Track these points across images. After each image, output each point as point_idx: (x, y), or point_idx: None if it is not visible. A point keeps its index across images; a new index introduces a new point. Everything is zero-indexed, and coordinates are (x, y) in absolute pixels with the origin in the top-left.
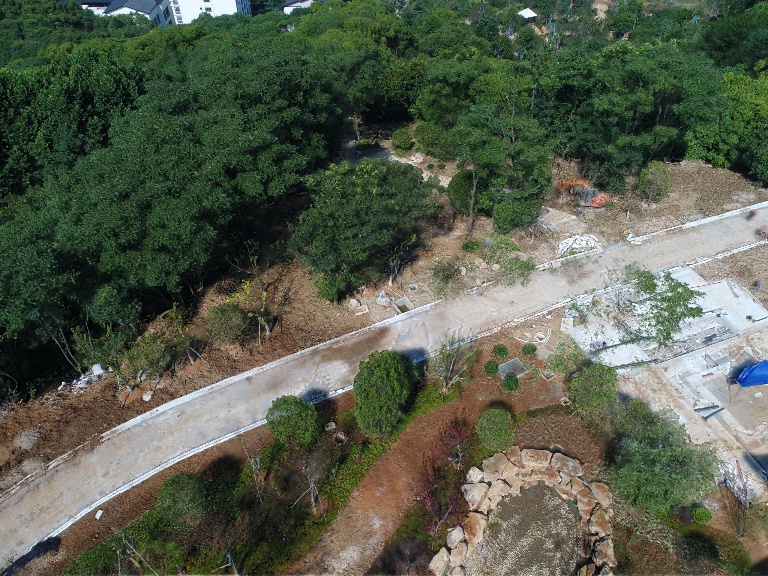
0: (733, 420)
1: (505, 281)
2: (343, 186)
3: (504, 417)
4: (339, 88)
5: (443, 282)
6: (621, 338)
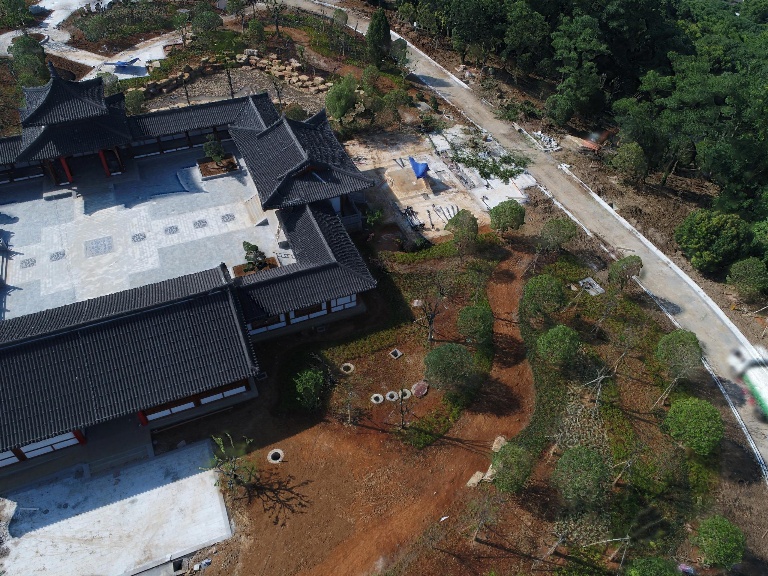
0: (394, 169)
1: (496, 111)
2: (504, 6)
3: (373, 70)
4: (676, 38)
5: (486, 89)
6: (454, 143)
